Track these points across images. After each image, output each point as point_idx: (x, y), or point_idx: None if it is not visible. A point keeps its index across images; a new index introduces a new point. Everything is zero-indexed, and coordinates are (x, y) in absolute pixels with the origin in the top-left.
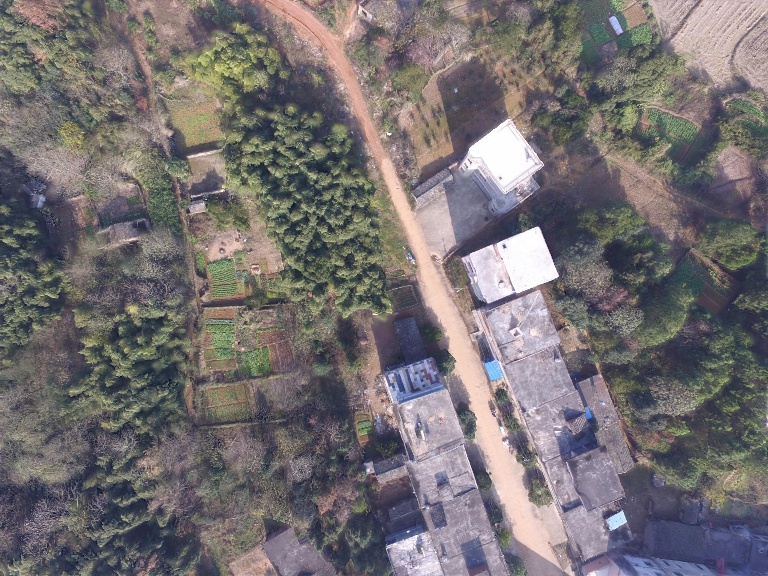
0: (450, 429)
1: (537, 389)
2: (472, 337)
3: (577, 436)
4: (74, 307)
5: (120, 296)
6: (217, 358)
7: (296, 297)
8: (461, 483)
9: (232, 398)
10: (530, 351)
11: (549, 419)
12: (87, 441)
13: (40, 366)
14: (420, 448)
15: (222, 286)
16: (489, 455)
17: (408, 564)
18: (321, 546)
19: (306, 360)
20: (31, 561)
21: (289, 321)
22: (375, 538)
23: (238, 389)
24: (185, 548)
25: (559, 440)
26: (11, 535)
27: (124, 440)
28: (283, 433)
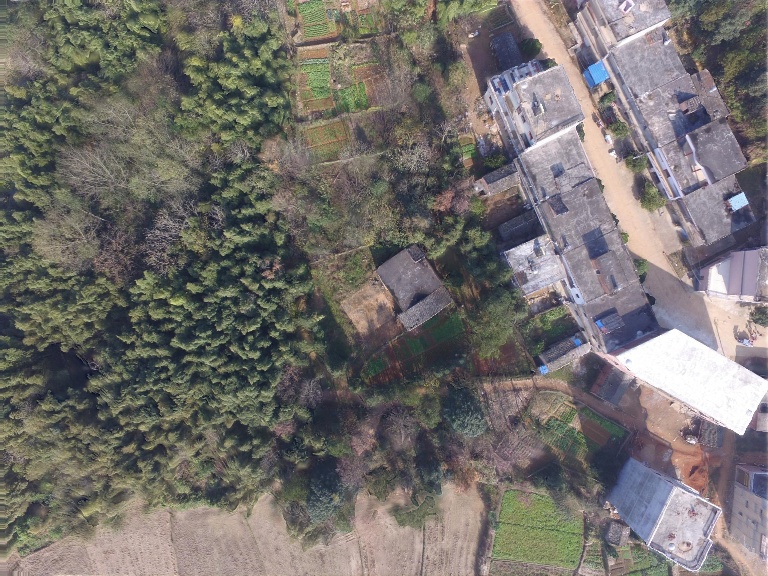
0: (567, 106)
1: (648, 74)
2: (570, 52)
3: (692, 119)
4: (175, 34)
5: (221, 17)
6: (314, 97)
7: (397, 2)
8: (578, 174)
9: (332, 136)
10: (641, 27)
11: (662, 104)
12: (198, 163)
13: (149, 86)
14: (538, 127)
15: (313, 26)
16: (596, 168)
17: (527, 269)
18: (442, 244)
19: (404, 89)
20: (155, 274)
21: (383, 55)
22: (492, 244)
23: (337, 127)
24: (303, 265)
25: (674, 124)
26: (131, 259)
27: (239, 148)
28: (398, 126)
